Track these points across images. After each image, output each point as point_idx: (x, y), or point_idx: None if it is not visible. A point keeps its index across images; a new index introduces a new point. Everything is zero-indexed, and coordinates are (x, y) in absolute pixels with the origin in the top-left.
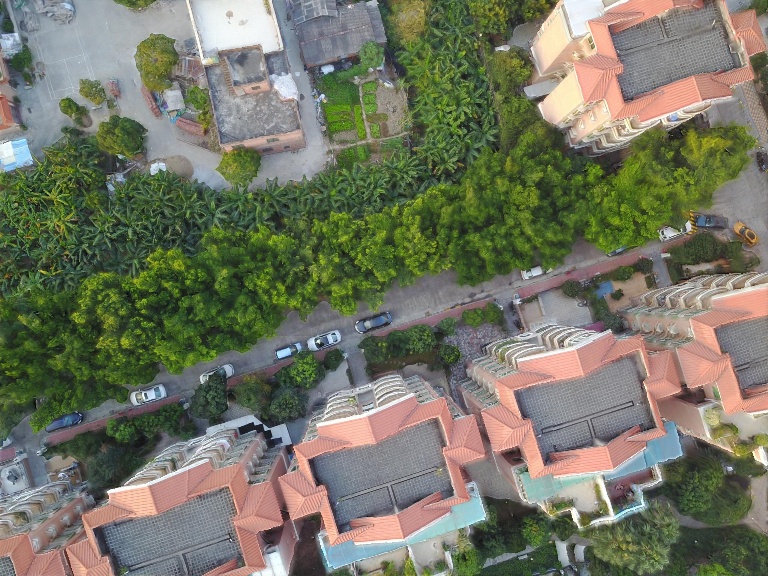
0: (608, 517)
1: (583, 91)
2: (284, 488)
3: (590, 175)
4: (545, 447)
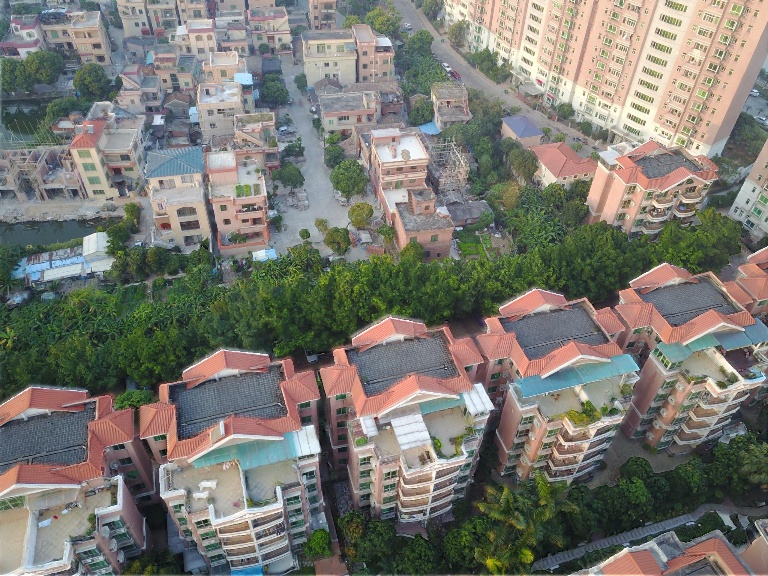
0: (740, 381)
1: (623, 180)
2: (482, 340)
3: (642, 239)
4: None
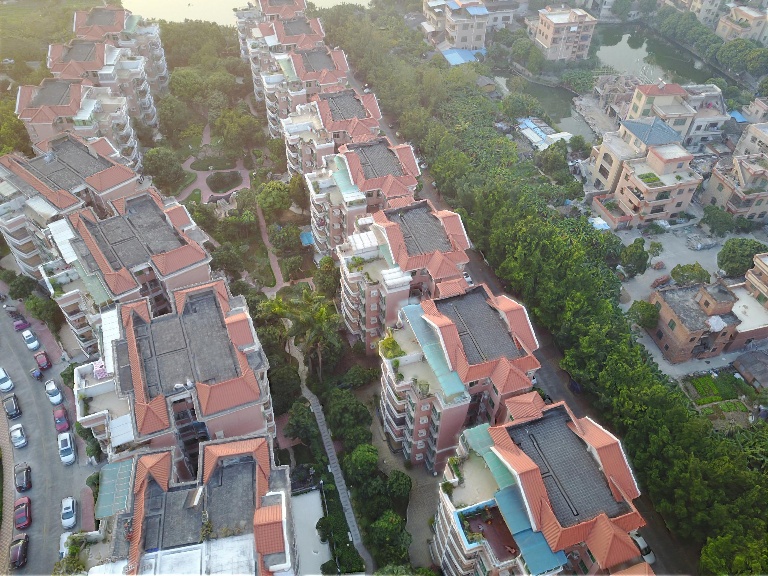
0: None
1: None
2: None
3: None
4: (518, 437)
